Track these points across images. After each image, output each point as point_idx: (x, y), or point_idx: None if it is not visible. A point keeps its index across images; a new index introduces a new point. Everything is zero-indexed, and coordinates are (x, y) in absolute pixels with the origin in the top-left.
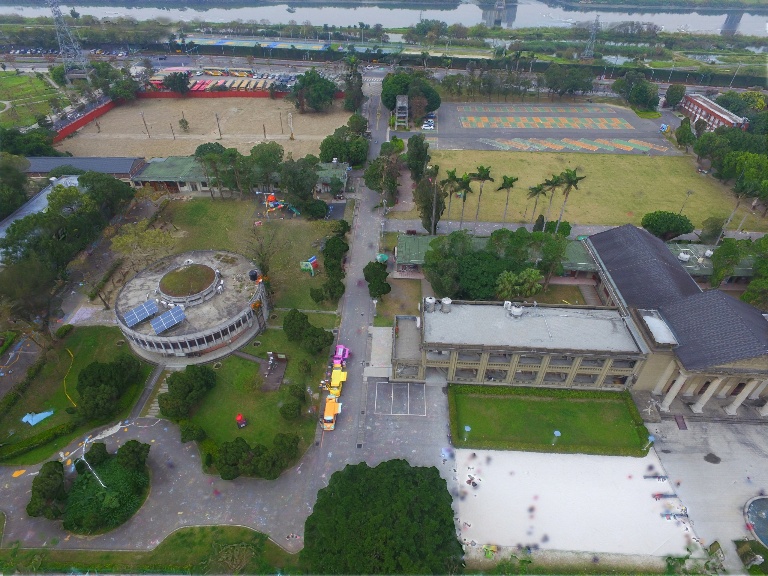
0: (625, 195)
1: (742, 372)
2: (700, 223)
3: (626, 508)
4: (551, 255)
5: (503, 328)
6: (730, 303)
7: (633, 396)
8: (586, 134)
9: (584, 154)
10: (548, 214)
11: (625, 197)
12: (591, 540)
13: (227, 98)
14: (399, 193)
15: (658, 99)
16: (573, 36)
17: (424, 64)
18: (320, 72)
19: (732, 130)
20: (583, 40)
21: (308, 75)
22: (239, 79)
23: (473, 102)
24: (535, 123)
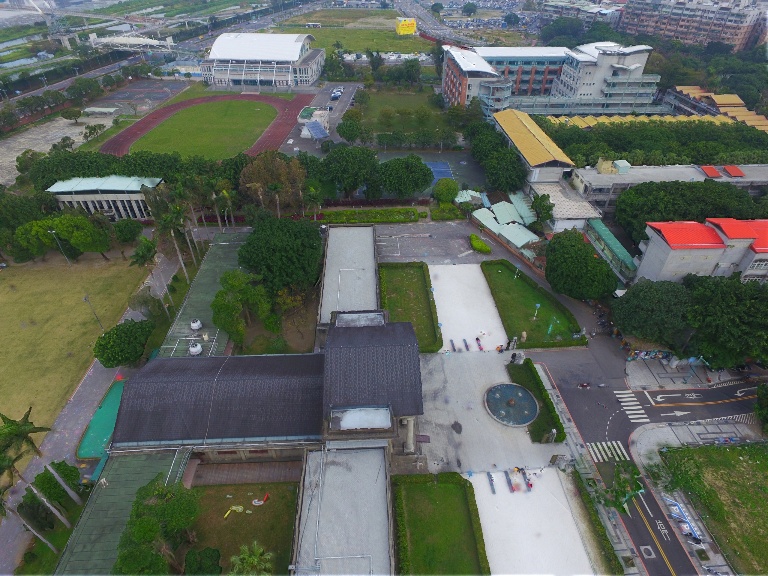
0: None
1: None
2: (111, 310)
3: (533, 522)
4: (194, 516)
5: None
6: (346, 345)
7: (400, 473)
8: None
9: None
10: None
11: (4, 364)
12: (581, 568)
13: None
14: None
15: None
16: None
17: None
18: None
19: None
20: None
21: None
22: None
23: None
24: None
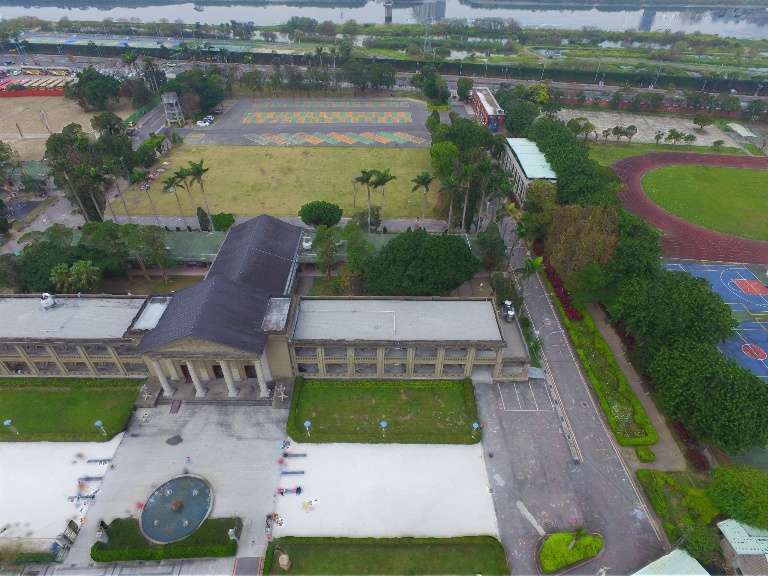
0: (336, 187)
1: (188, 354)
2: (385, 212)
3: (41, 493)
4: (129, 246)
5: (23, 320)
6: (217, 288)
7: (146, 382)
8: (358, 128)
9: (336, 147)
10: (242, 207)
11: (334, 189)
12: None
13: (23, 97)
14: (109, 189)
15: (449, 93)
16: (411, 32)
17: (225, 61)
18: (100, 70)
19: (461, 121)
20: (421, 36)
21: (85, 73)
22: (46, 78)
23: (276, 98)
24: (317, 118)
